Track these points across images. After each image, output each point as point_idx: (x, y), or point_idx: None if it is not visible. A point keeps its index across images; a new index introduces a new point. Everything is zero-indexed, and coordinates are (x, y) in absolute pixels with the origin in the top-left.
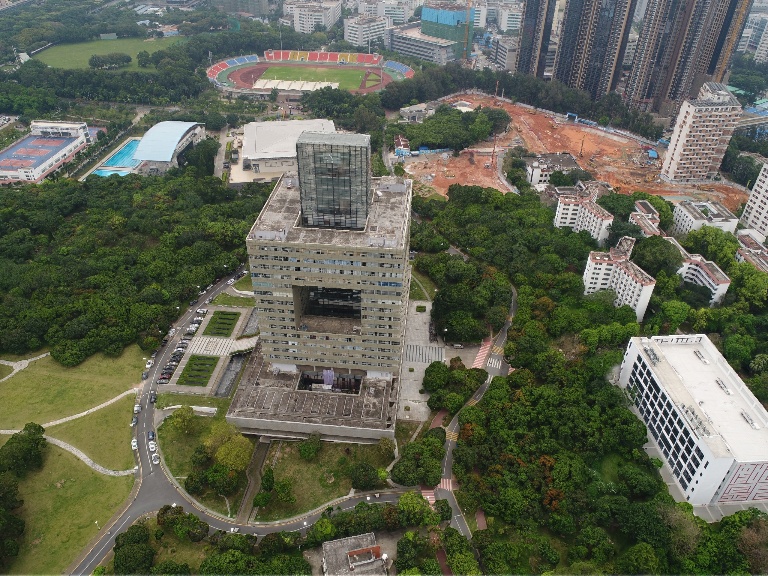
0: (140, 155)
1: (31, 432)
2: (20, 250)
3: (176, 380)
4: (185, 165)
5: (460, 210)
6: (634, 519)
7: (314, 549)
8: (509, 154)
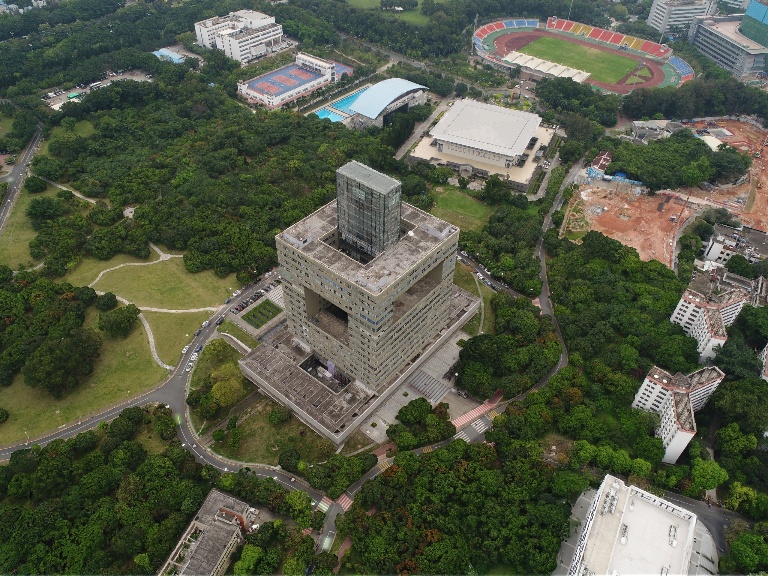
0: (355, 106)
1: (129, 311)
2: (219, 166)
3: (243, 314)
4: (391, 124)
5: (583, 260)
6: None
7: (220, 490)
8: (705, 214)
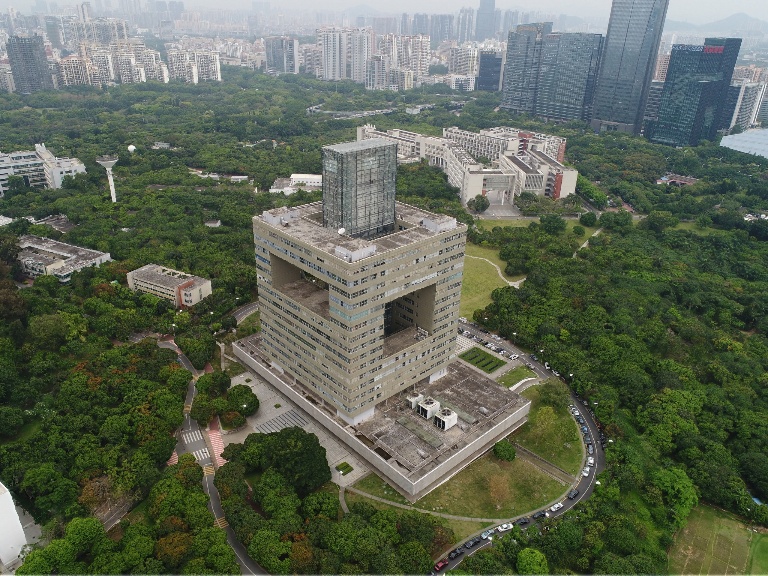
0: None
1: None
2: None
3: None
4: None
5: None
6: (8, 371)
7: None
8: None
